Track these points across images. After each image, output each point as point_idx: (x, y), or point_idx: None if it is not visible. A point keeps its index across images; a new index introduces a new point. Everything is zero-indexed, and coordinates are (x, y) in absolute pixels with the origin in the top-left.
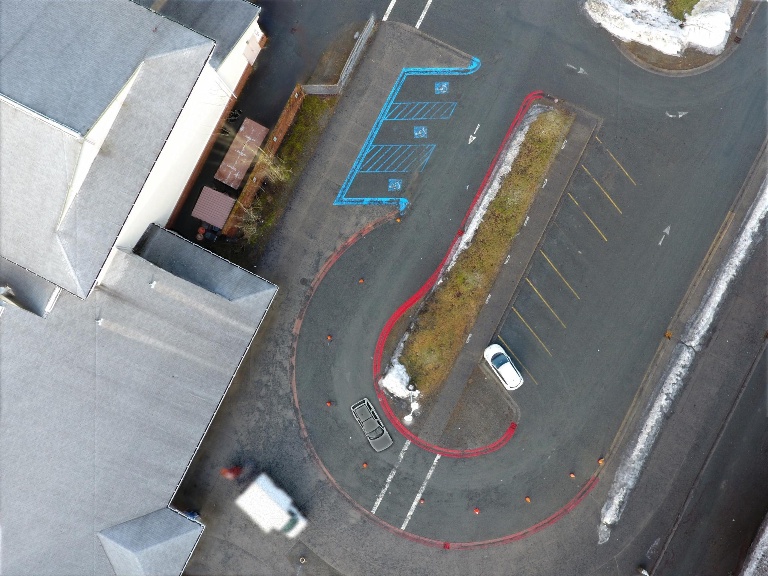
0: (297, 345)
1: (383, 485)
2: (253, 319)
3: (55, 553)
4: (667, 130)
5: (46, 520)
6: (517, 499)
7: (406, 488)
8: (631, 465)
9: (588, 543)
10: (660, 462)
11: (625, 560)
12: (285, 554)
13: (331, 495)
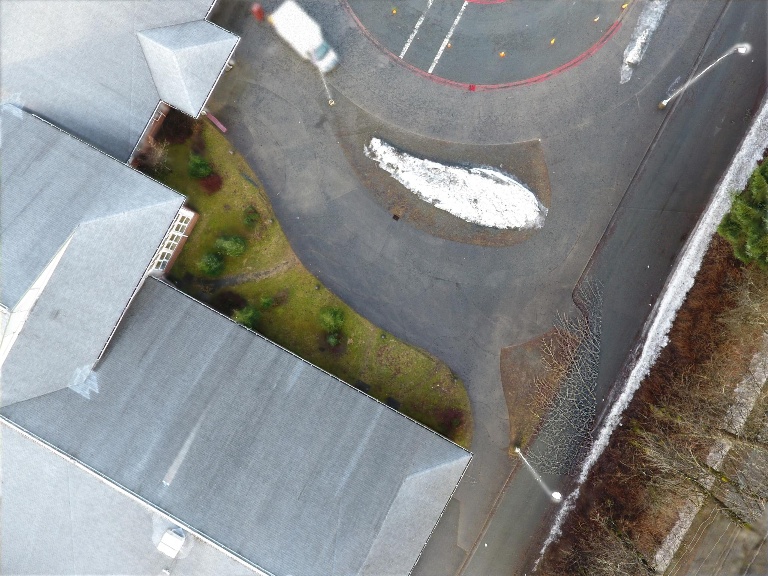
0: None
1: (411, 31)
2: None
3: (96, 45)
4: None
5: (89, 9)
6: (542, 43)
7: (434, 33)
8: (654, 9)
9: (610, 83)
10: (682, 6)
11: (646, 97)
12: (315, 97)
13: (361, 41)
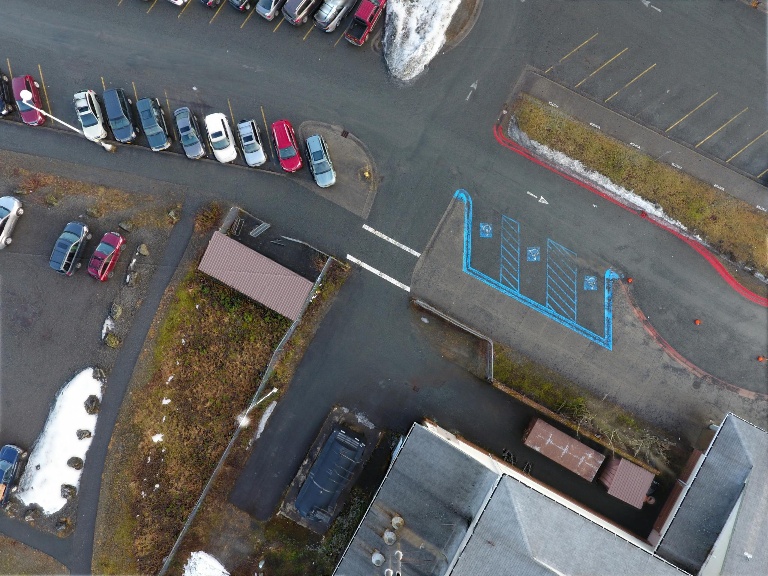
0: (767, 395)
1: None
2: (767, 442)
3: None
4: (540, 1)
5: None
6: None
7: None
8: None
9: None
10: None
11: None
12: None
13: None
